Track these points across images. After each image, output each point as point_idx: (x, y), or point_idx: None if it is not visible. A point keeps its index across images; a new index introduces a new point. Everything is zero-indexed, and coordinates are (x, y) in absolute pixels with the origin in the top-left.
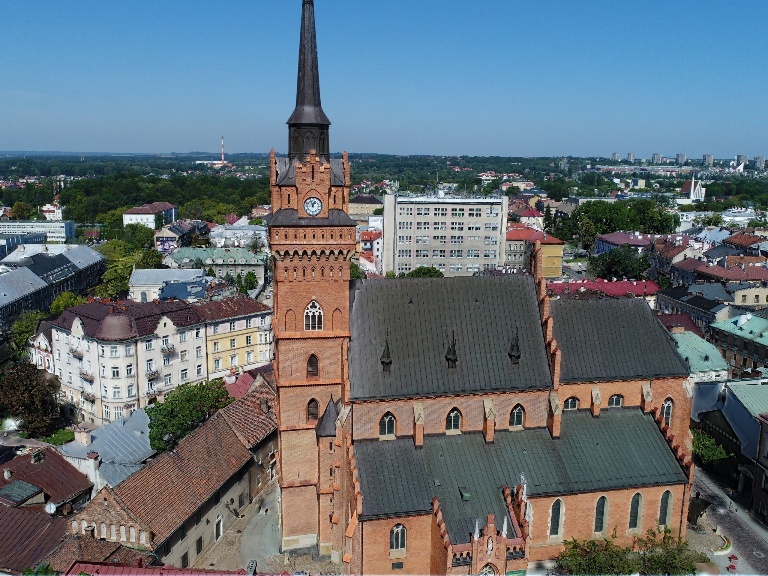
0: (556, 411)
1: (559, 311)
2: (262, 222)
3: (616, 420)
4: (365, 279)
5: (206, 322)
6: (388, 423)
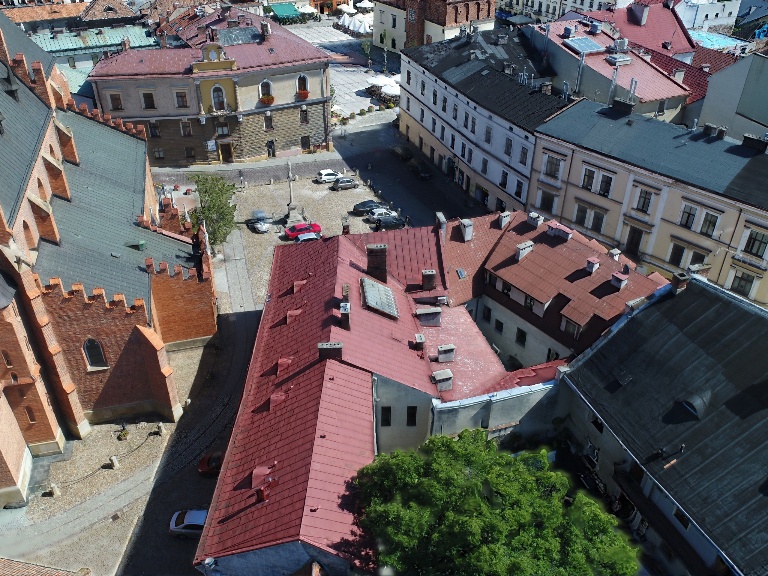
0: (71, 134)
1: None
2: None
3: None
4: None
5: None
6: None
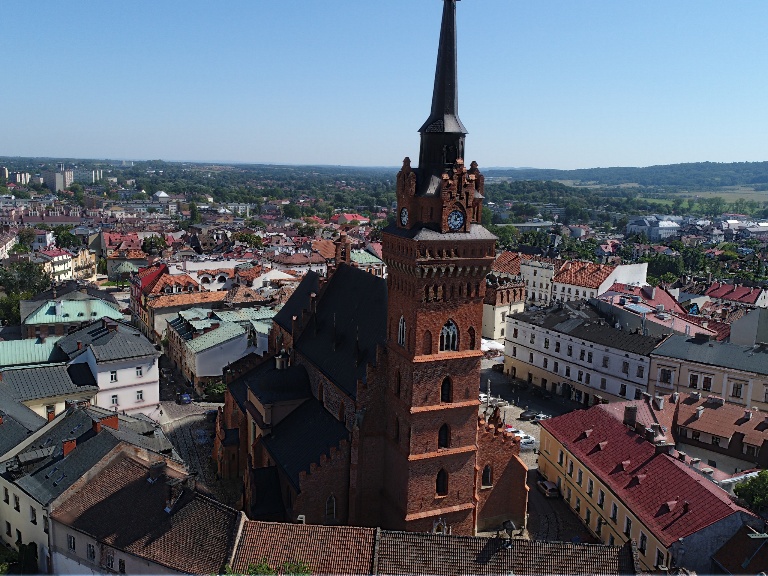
0: None
1: None
2: None
3: None
4: None
5: None
6: None
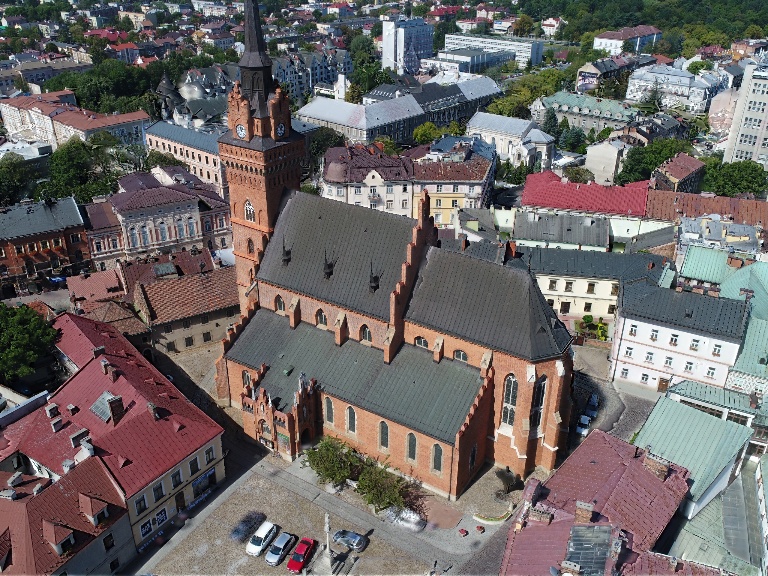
0: (386, 342)
1: (440, 260)
2: (704, 65)
3: (451, 371)
4: (298, 191)
5: (413, 181)
6: (283, 303)
